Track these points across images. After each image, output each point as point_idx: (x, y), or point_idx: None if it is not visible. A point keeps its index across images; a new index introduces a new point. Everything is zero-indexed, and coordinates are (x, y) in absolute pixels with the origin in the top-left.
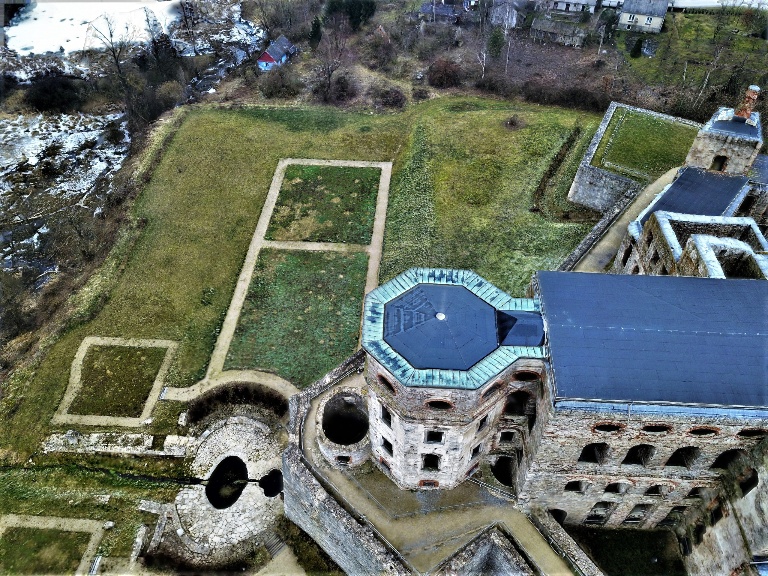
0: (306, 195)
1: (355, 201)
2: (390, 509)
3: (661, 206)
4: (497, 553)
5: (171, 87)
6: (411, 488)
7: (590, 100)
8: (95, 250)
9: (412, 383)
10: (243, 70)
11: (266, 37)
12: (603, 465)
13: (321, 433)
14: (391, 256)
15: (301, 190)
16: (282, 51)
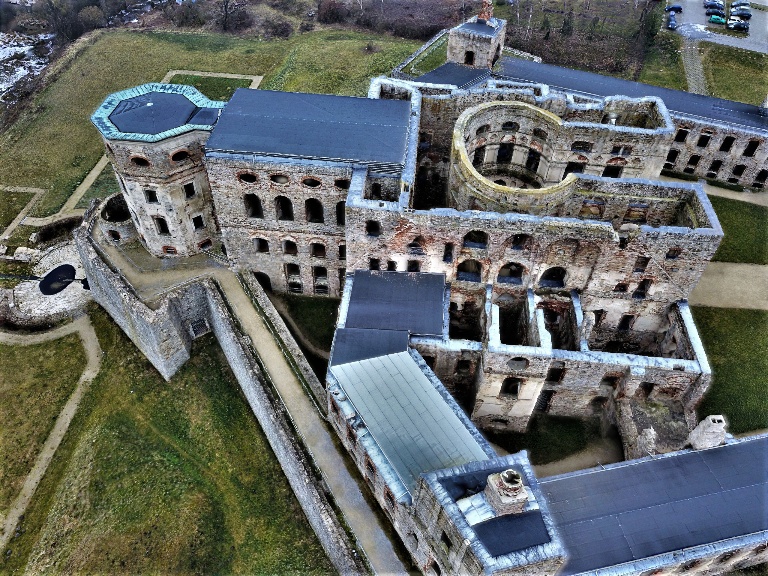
0: None
1: None
2: (140, 267)
3: None
4: (207, 295)
5: (91, 11)
6: (160, 256)
7: None
8: (1, 130)
9: (112, 137)
10: (165, 5)
11: None
12: (265, 219)
13: (99, 215)
14: None
15: None
16: None
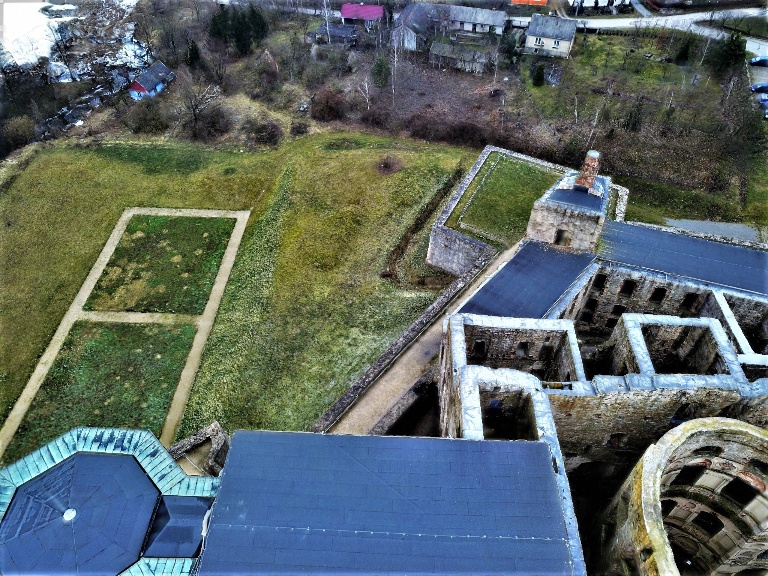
0: (144, 253)
1: (197, 260)
2: None
3: (484, 295)
4: None
5: (20, 123)
6: None
7: (478, 137)
8: None
9: None
10: (117, 99)
11: (150, 61)
12: None
13: None
14: (219, 331)
15: (140, 246)
16: (157, 79)
